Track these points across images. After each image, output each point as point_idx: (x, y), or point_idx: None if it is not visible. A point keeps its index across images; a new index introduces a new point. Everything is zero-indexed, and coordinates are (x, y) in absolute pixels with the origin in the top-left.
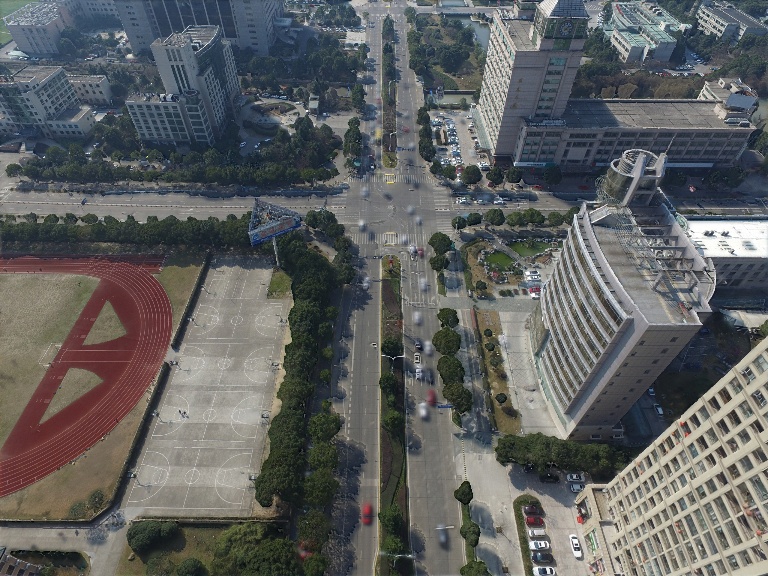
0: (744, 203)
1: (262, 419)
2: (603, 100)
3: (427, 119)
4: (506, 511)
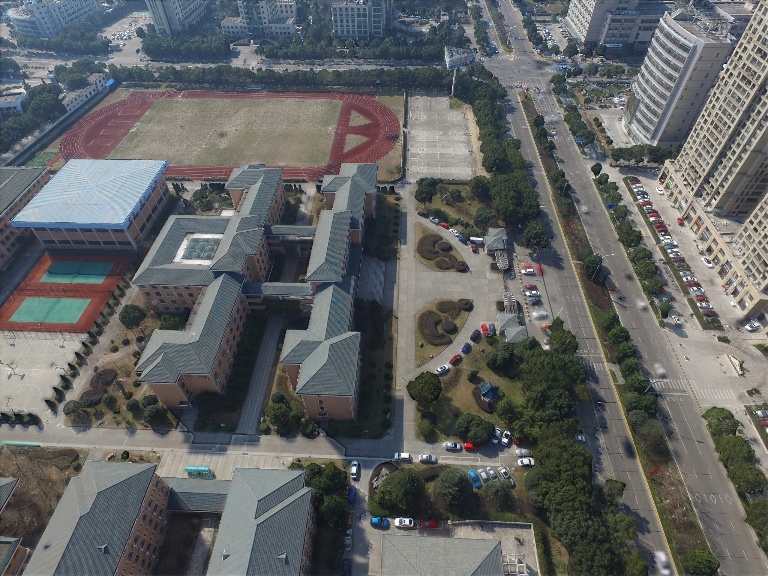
0: None
1: (469, 152)
2: (663, 2)
3: (532, 23)
4: (619, 182)
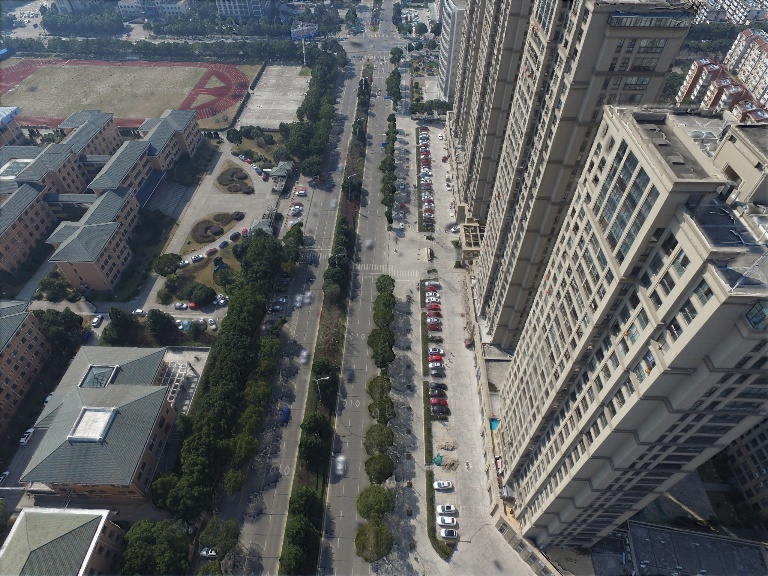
0: None
1: None
2: None
3: None
4: (412, 131)
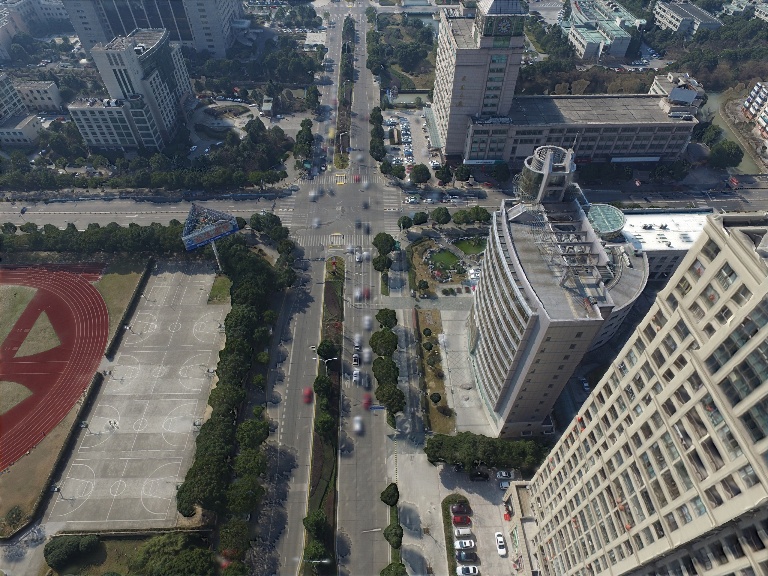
0: (690, 196)
1: (194, 427)
2: (551, 96)
3: (380, 119)
4: (434, 511)
